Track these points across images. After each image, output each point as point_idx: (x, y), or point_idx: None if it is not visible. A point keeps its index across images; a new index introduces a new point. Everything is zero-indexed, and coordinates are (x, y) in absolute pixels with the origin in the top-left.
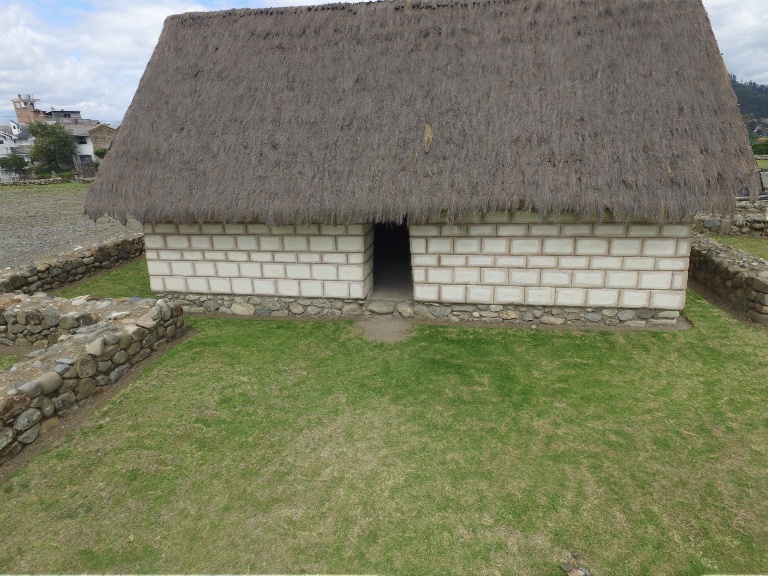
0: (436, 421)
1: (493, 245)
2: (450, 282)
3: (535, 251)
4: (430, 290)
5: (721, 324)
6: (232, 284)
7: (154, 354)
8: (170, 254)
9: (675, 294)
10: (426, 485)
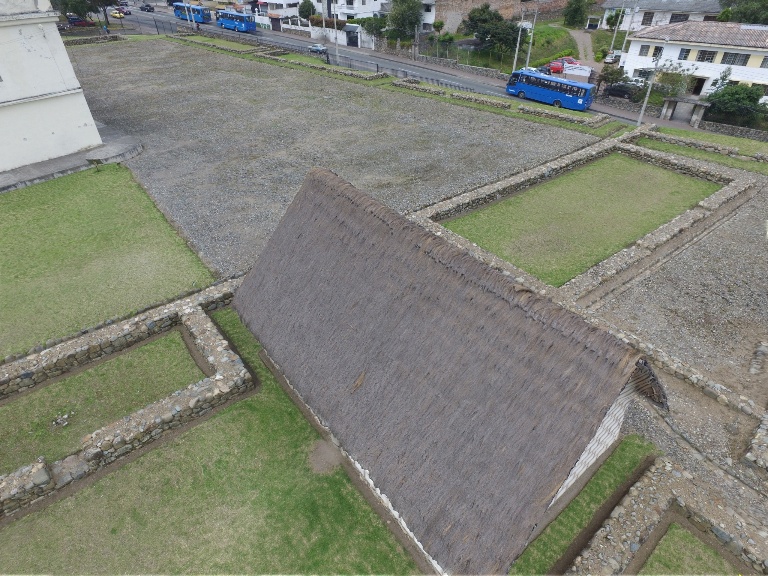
0: (265, 545)
1: None
2: None
3: None
4: None
5: None
6: None
7: (228, 402)
8: None
9: None
10: (225, 573)
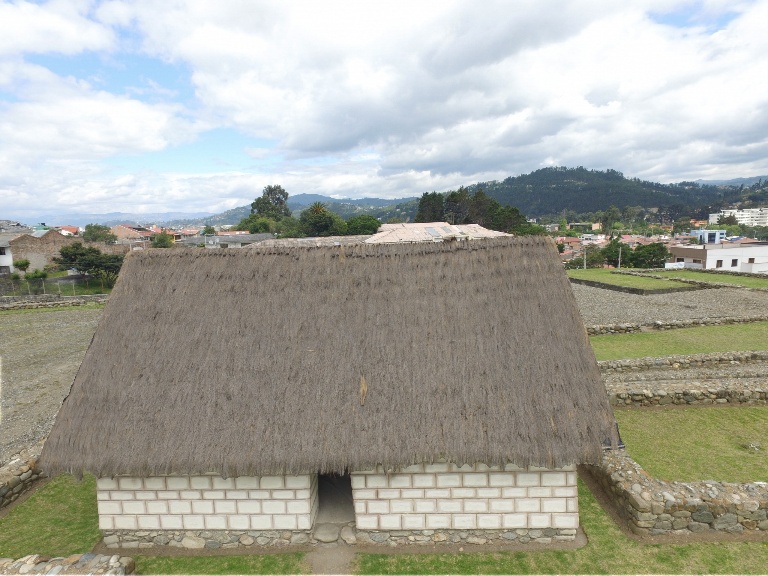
0: None
1: (422, 481)
2: (387, 512)
3: (457, 485)
4: (370, 520)
5: (609, 538)
6: (184, 520)
7: None
8: (122, 495)
9: (571, 516)
10: None
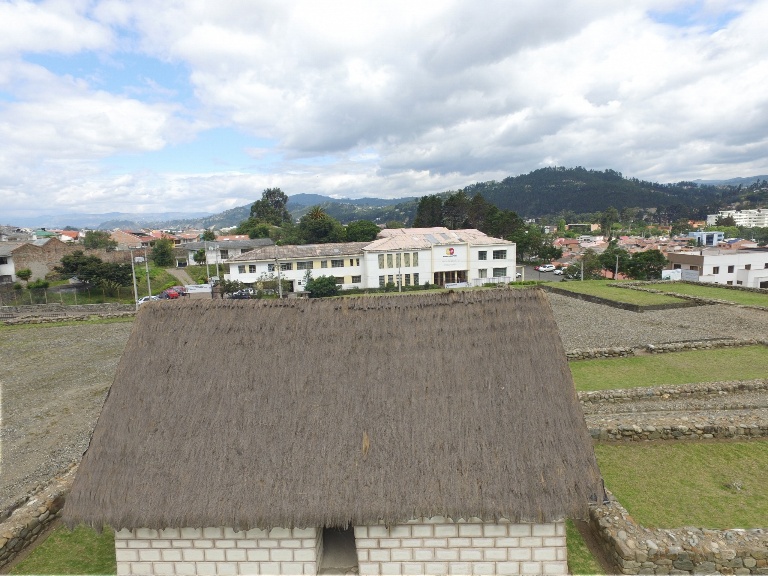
0: None
1: (421, 531)
2: (388, 561)
3: (453, 535)
4: (372, 568)
5: None
6: (197, 567)
7: None
8: (139, 544)
9: (560, 564)
10: None
